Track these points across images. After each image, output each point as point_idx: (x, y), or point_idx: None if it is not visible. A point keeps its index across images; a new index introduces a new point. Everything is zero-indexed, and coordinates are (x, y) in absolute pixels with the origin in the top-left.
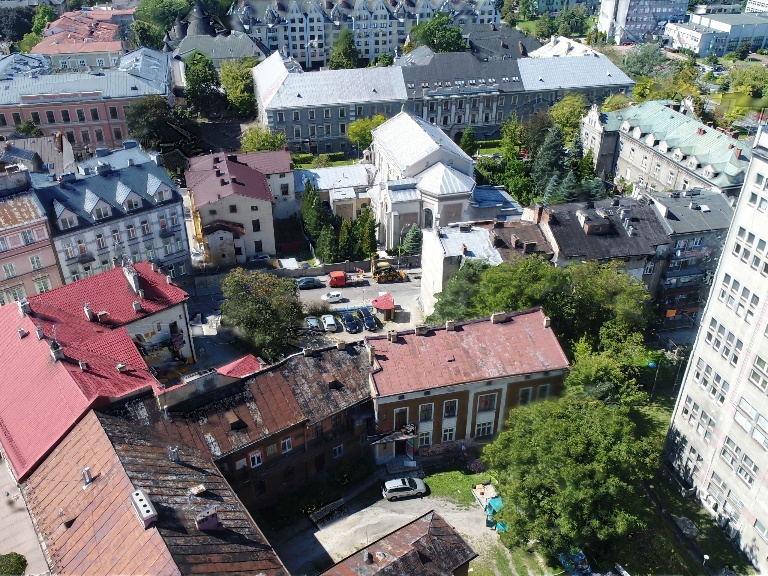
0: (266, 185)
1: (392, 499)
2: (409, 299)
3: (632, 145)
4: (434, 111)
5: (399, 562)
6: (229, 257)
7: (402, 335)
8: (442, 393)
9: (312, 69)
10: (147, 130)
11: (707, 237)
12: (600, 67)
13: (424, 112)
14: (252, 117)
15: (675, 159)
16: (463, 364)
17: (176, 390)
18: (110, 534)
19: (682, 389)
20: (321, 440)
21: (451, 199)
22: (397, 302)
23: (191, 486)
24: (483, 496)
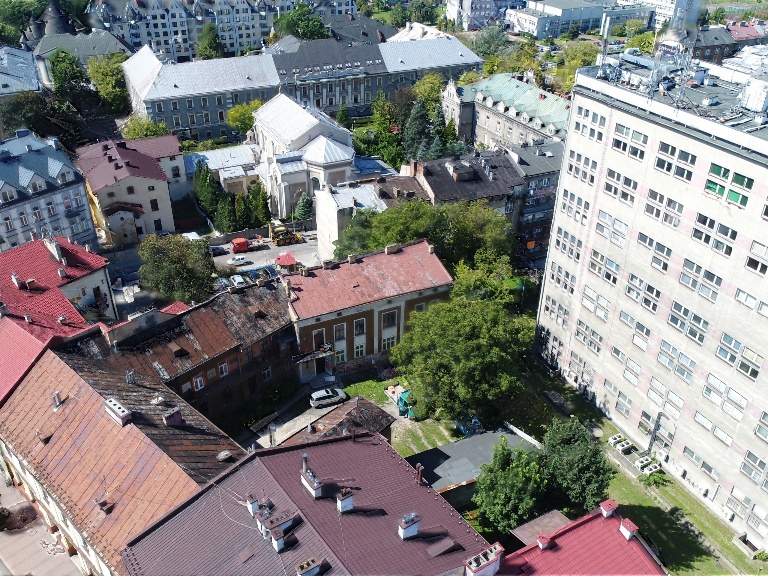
0: (159, 167)
1: (319, 407)
2: (308, 257)
3: (487, 113)
4: (307, 95)
5: (337, 427)
6: (131, 236)
7: (312, 270)
8: (352, 313)
9: (185, 60)
10: (25, 126)
11: (553, 177)
12: (452, 48)
13: (297, 96)
14: (126, 112)
15: (523, 122)
16: (366, 288)
17: (122, 327)
18: (89, 438)
19: (542, 291)
20: (252, 364)
21: (335, 167)
22: (297, 260)
23: (151, 399)
24: (394, 394)
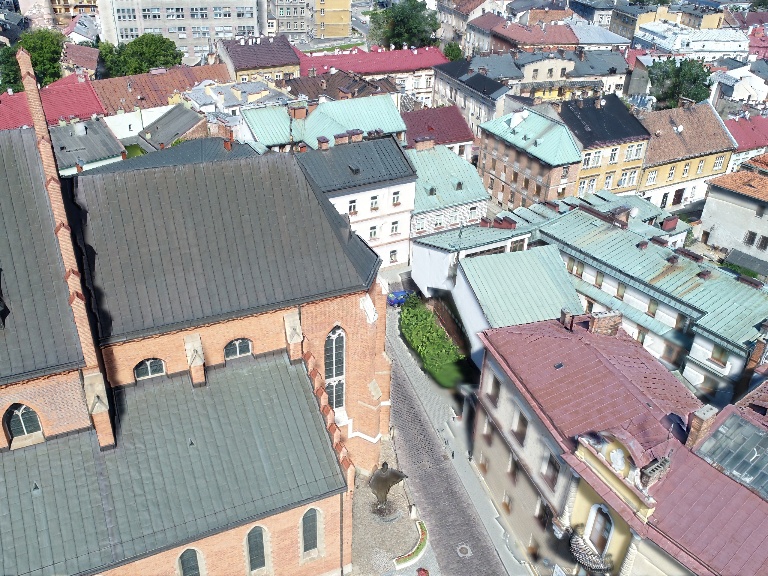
0: None
1: None
2: None
3: None
4: None
5: None
6: None
7: None
8: None
9: None
10: None
11: None
12: None
13: None
14: None
15: None
16: None
17: None
18: None
19: None
20: None
21: None
22: None
23: None
24: None
